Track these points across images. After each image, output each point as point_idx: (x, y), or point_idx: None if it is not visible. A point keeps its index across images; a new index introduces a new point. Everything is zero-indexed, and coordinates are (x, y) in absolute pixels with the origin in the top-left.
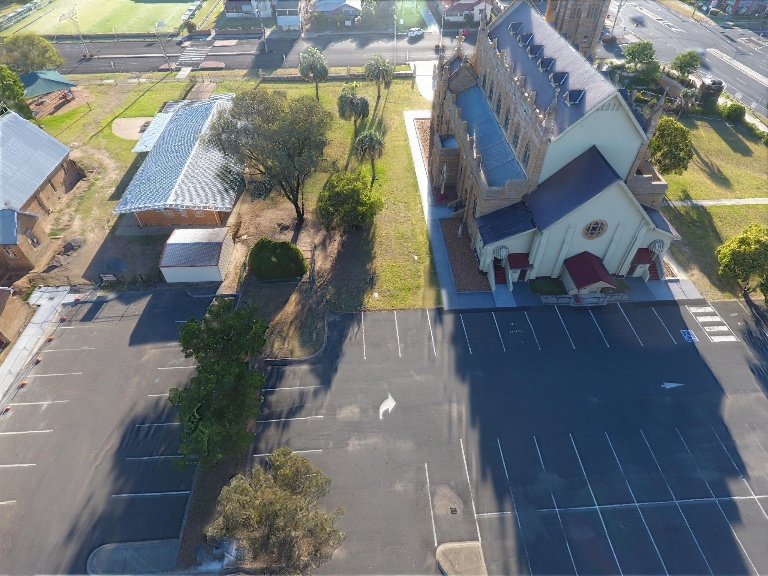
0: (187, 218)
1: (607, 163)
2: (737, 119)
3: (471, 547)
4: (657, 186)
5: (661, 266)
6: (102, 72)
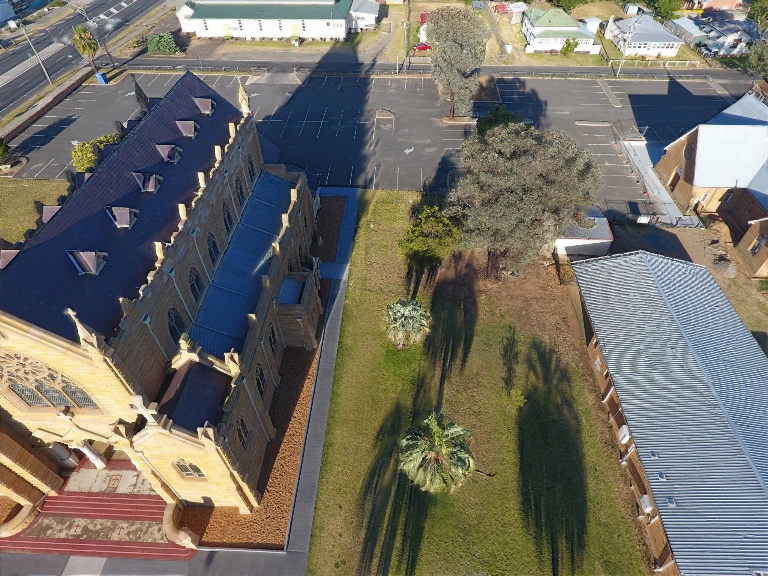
0: None
1: None
2: None
3: (380, 116)
4: None
5: None
6: None
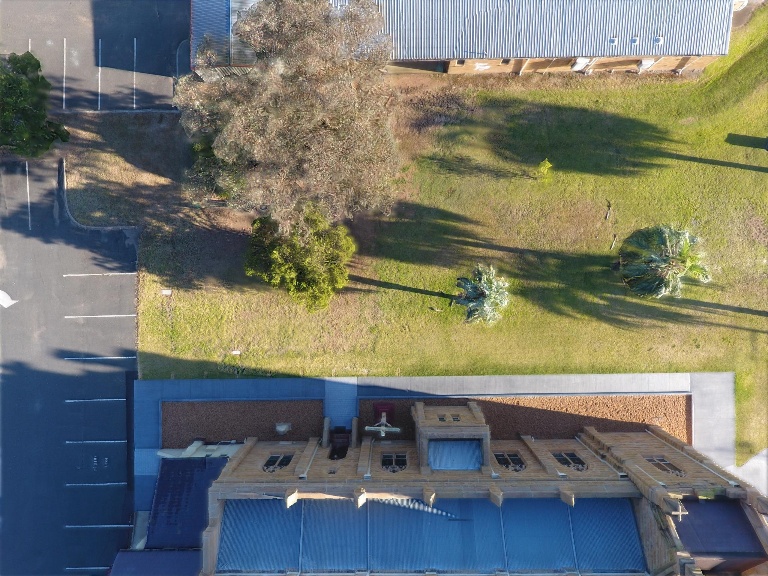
0: None
1: None
2: None
3: None
4: None
5: None
6: None
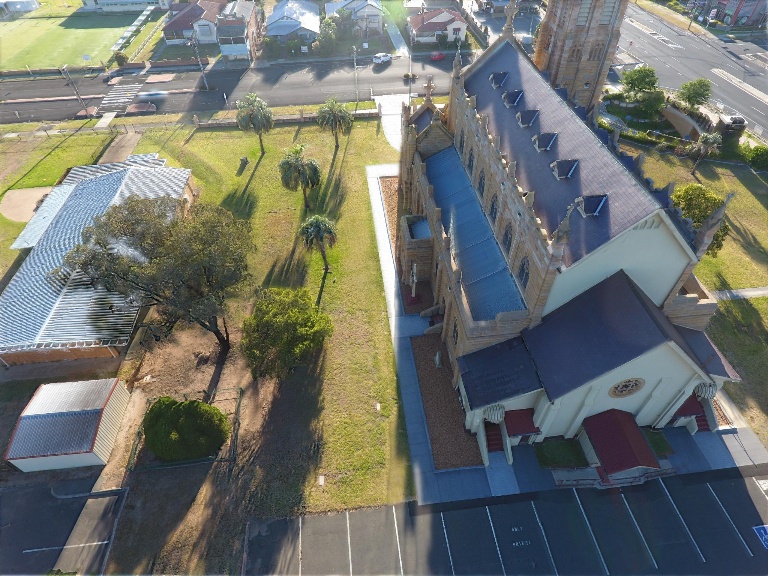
0: (70, 353)
1: (645, 306)
2: (764, 165)
3: None
4: (703, 307)
5: (712, 413)
6: (7, 122)
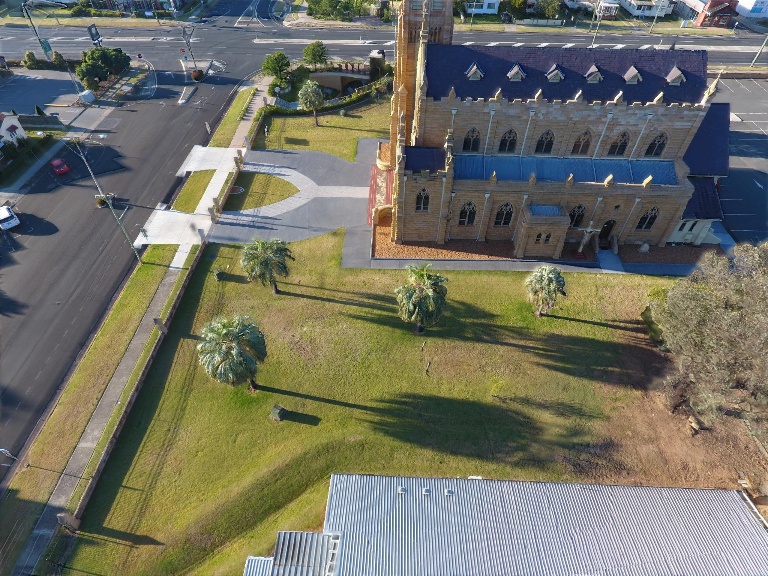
0: None
1: None
2: None
3: None
4: None
5: None
6: None
